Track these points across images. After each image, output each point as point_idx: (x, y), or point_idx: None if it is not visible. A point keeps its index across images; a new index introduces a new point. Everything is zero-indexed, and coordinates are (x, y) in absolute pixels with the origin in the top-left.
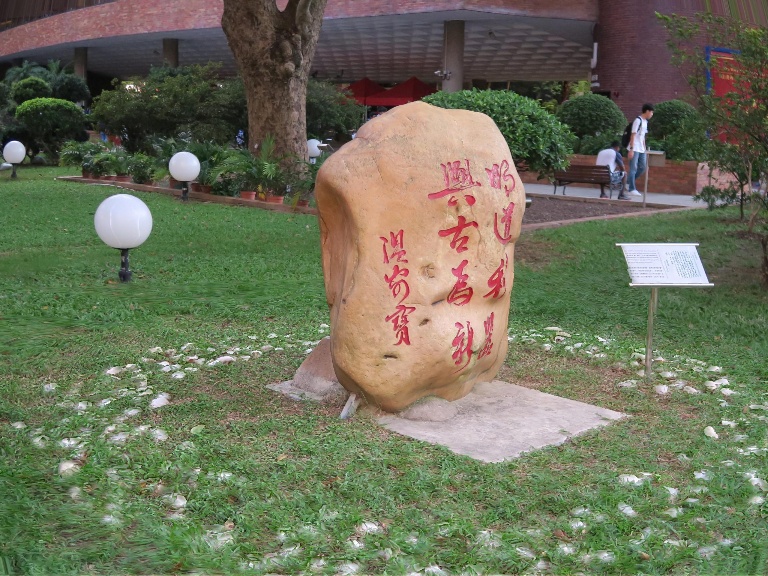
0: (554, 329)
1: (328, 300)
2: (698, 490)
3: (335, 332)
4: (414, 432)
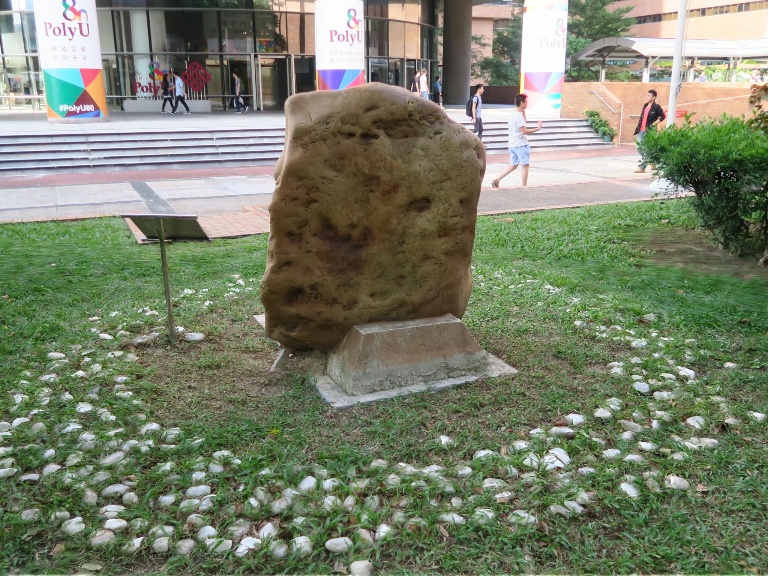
0: None
1: None
2: None
3: None
4: None
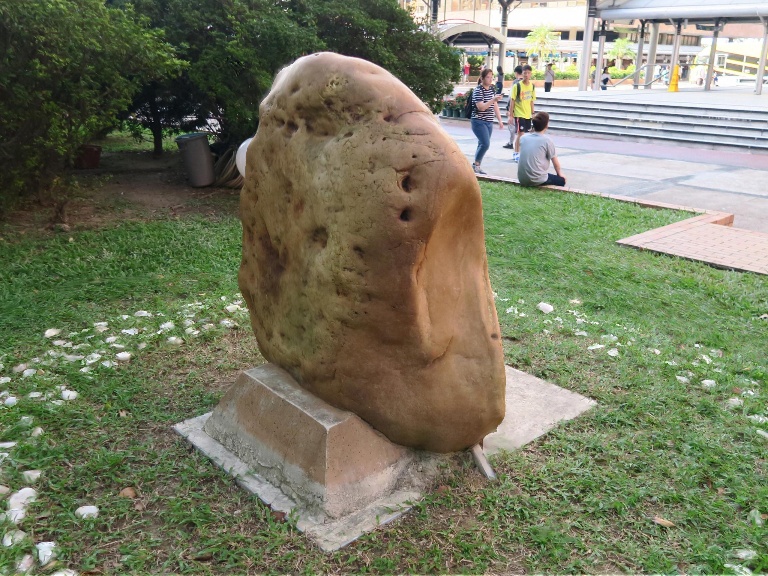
0: (56, 332)
1: (437, 354)
2: (616, 338)
3: (497, 380)
4: (523, 434)
